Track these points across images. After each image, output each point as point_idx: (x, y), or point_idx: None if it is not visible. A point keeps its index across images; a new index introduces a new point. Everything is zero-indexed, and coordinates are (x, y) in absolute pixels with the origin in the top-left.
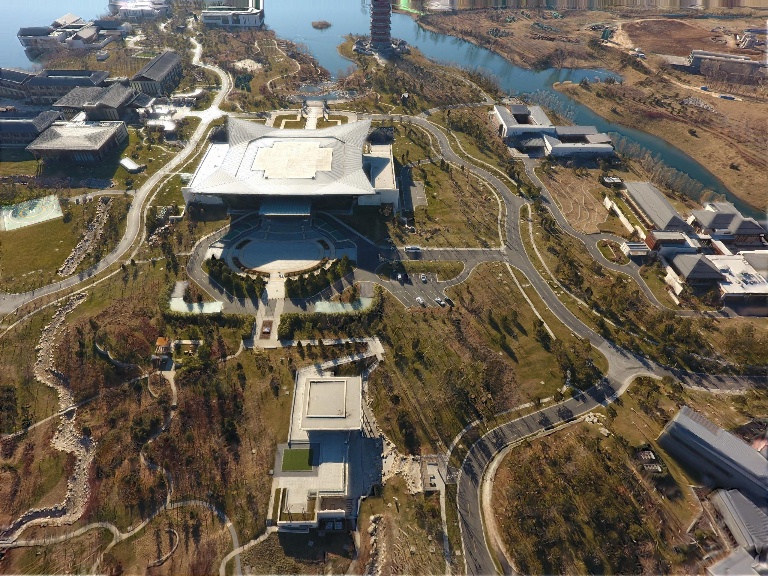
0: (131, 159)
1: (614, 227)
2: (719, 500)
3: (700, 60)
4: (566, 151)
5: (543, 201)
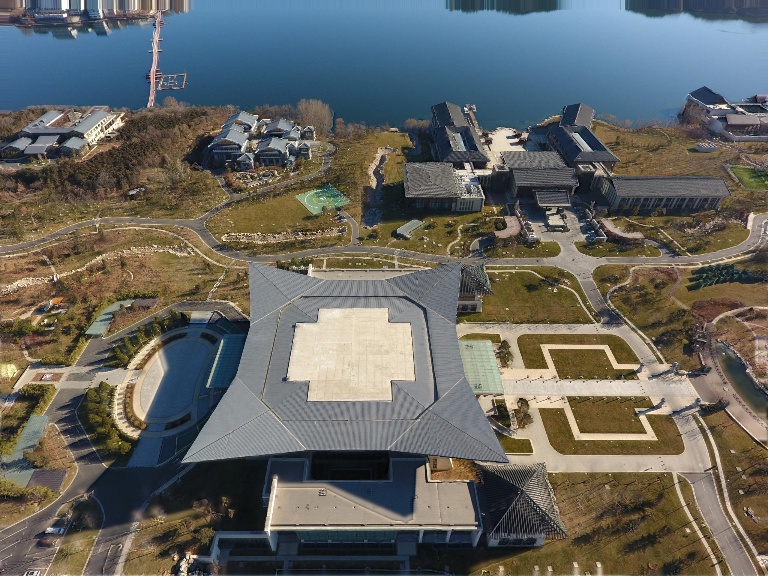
0: (420, 225)
1: None
2: None
3: None
4: None
5: None
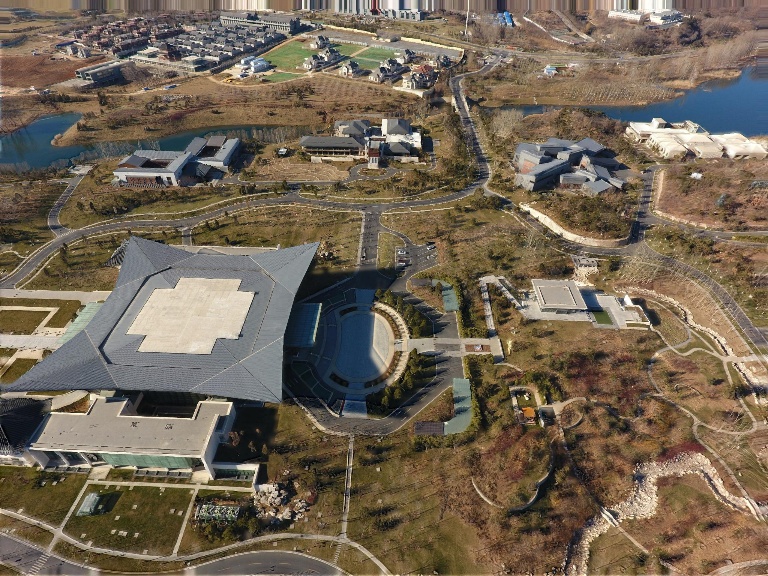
0: None
1: (344, 165)
2: (567, 180)
3: (96, 74)
4: (227, 159)
5: (298, 186)
